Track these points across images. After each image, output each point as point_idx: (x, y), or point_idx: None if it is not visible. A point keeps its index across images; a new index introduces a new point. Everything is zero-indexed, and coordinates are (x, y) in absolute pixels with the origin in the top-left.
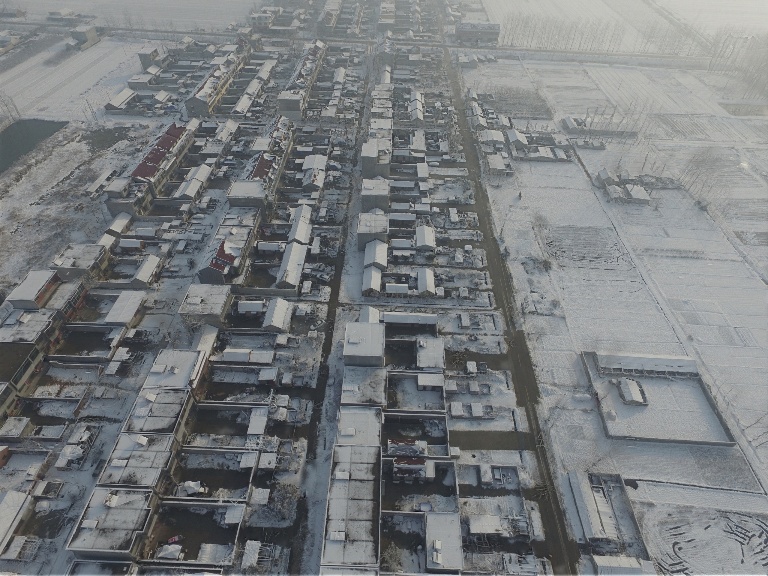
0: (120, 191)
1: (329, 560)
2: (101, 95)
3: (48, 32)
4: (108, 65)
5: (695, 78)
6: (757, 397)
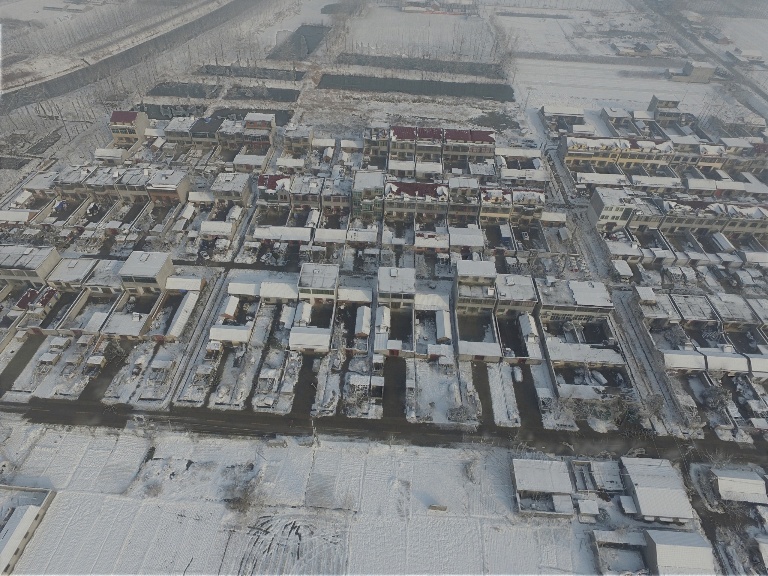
0: (370, 127)
1: None
2: (576, 105)
3: (698, 60)
4: (648, 97)
5: None
6: None
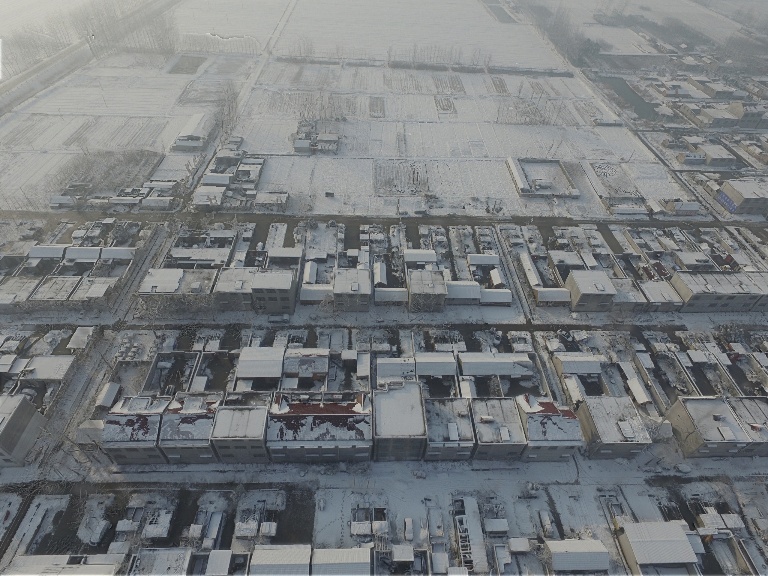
0: None
1: (759, 291)
2: None
3: None
4: None
5: (107, 68)
6: (521, 149)
